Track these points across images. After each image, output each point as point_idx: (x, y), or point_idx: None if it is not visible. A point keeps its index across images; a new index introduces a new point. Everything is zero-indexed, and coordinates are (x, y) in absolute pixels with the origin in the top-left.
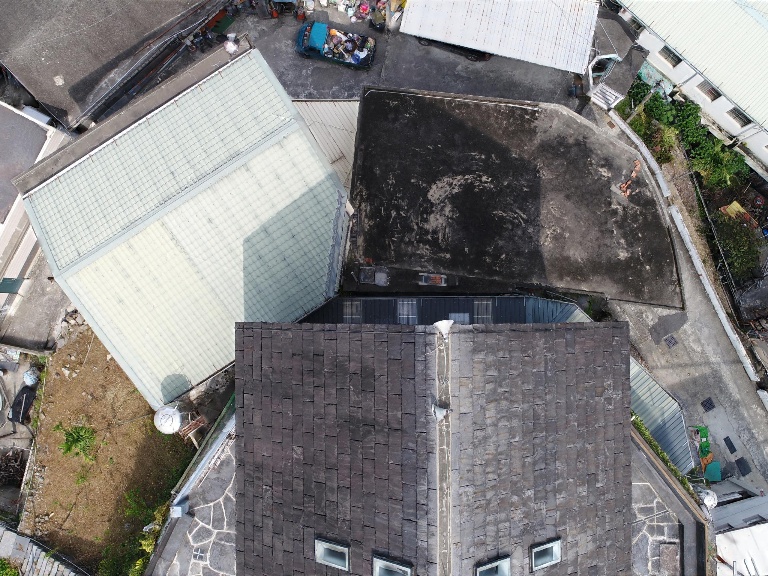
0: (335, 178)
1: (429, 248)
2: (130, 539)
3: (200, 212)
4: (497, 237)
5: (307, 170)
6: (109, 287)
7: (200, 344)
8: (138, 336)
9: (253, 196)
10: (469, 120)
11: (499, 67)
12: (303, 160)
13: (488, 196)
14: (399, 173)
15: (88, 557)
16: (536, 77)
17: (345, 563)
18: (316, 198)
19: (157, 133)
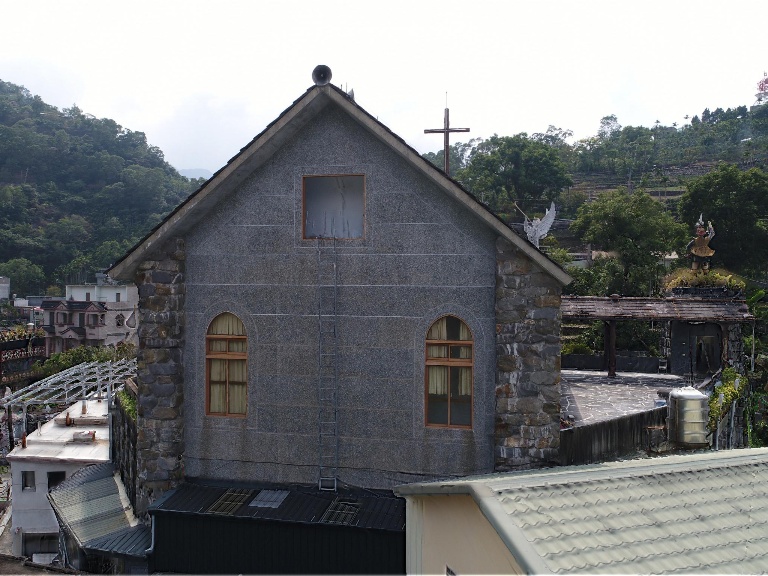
0: None
1: None
2: None
3: None
4: None
5: None
6: None
7: None
8: None
9: None
10: None
11: None
12: None
13: None
14: None
15: None
16: None
17: None
18: None
19: None
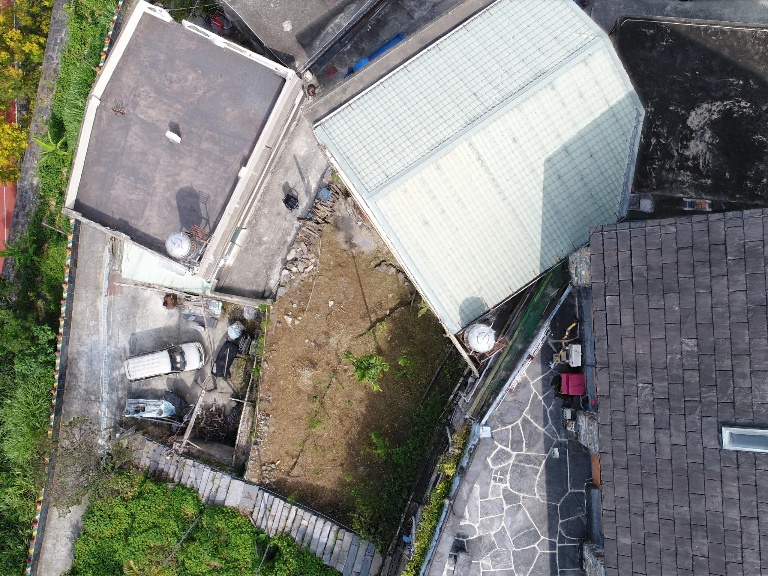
0: (635, 96)
1: (690, 174)
2: (366, 482)
3: (506, 132)
4: (758, 162)
5: (608, 88)
6: (416, 209)
7: (498, 266)
8: (440, 258)
9: (556, 115)
10: (726, 46)
11: (708, 6)
12: (605, 78)
13: (747, 121)
14: (658, 101)
15: (321, 502)
16: (745, 15)
17: (767, 445)
18: (615, 116)
19: (450, 57)
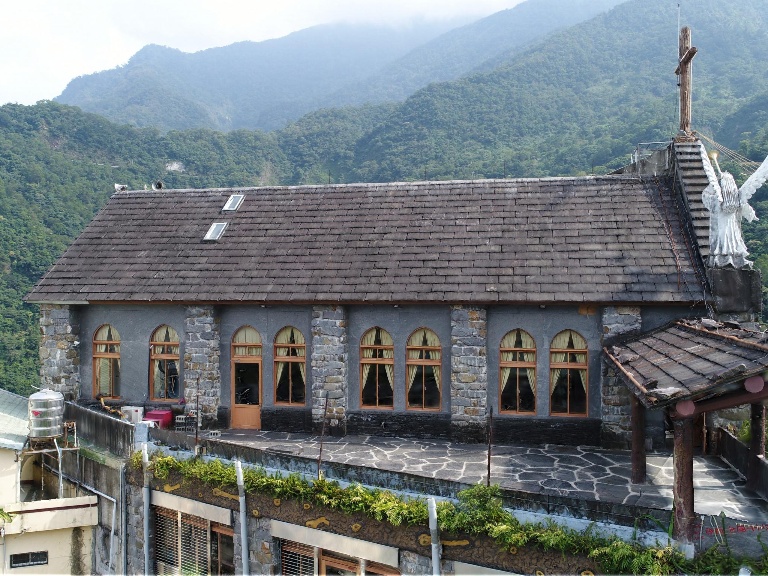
0: None
1: None
2: None
3: None
4: None
5: None
6: None
7: None
8: None
9: None
10: None
11: None
12: None
13: None
14: None
15: None
16: None
17: (222, 224)
18: None
19: None
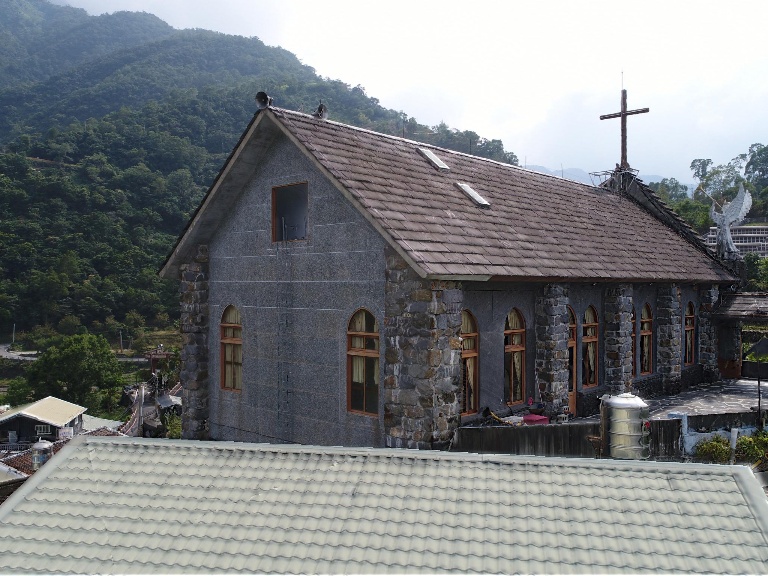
0: None
1: None
2: None
3: None
4: None
5: None
6: None
7: None
8: None
9: None
10: None
11: None
12: None
13: None
14: None
15: None
16: None
17: None
18: None
19: None
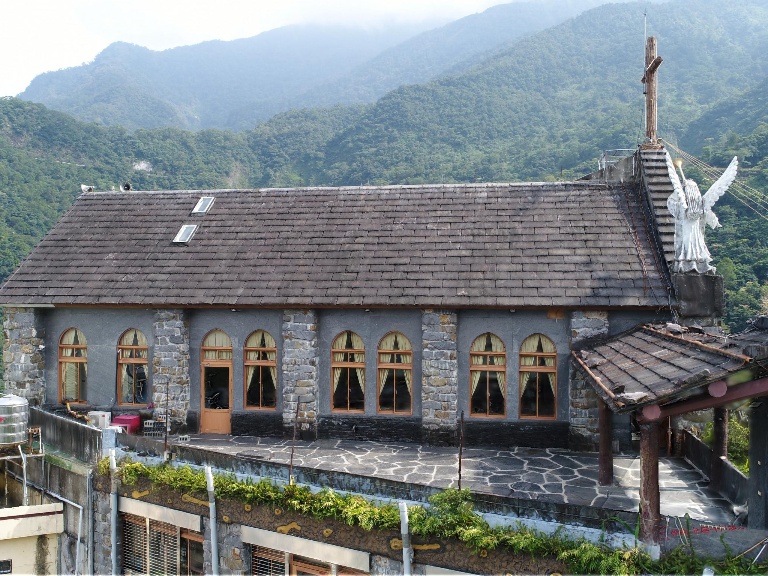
0: None
1: None
2: None
3: None
4: None
5: None
6: None
7: None
8: None
9: None
10: None
11: None
12: None
13: None
14: None
15: None
16: None
17: (192, 227)
18: None
19: None
